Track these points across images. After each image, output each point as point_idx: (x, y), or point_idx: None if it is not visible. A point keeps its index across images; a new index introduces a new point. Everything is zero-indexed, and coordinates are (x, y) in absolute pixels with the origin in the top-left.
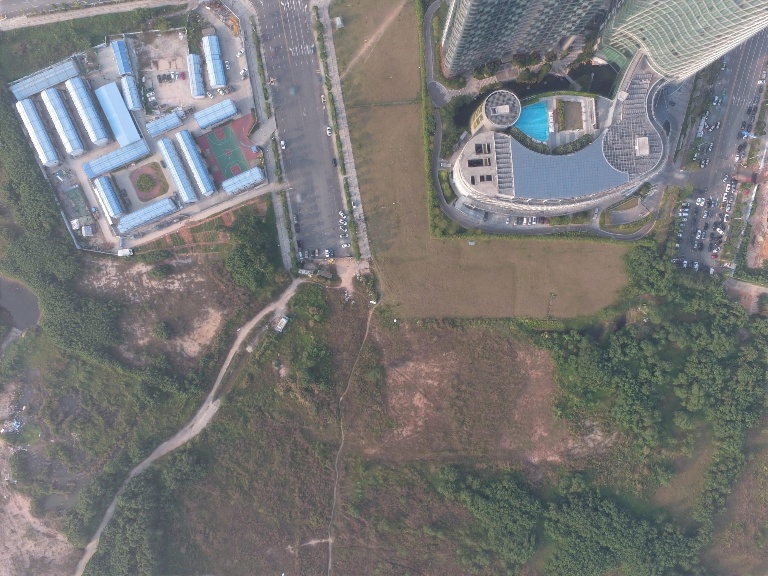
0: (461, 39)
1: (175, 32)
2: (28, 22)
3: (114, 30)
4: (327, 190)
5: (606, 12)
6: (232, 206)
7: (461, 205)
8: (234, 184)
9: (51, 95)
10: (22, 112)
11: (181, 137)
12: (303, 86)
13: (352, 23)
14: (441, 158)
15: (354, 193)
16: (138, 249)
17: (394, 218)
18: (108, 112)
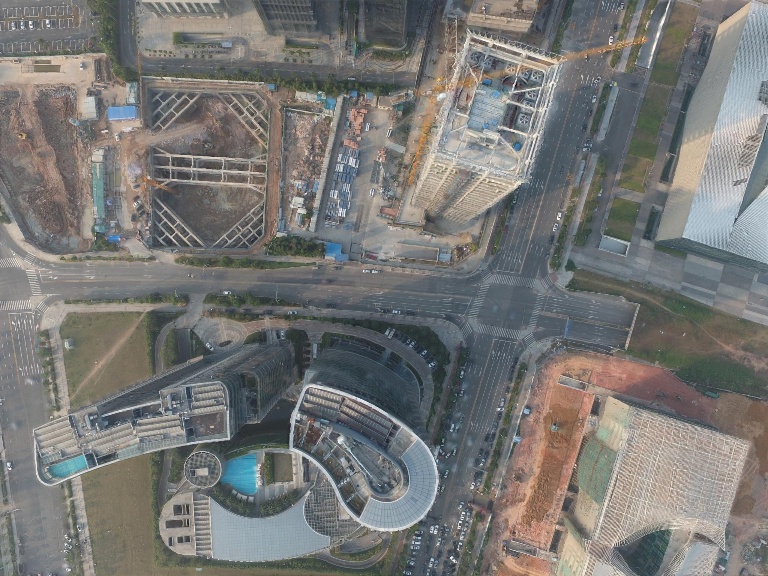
0: None
1: None
2: None
3: None
4: (53, 512)
5: None
6: None
7: None
8: None
9: None
10: None
11: None
12: (32, 406)
13: (83, 345)
14: None
15: (81, 515)
16: None
17: (120, 542)
18: None
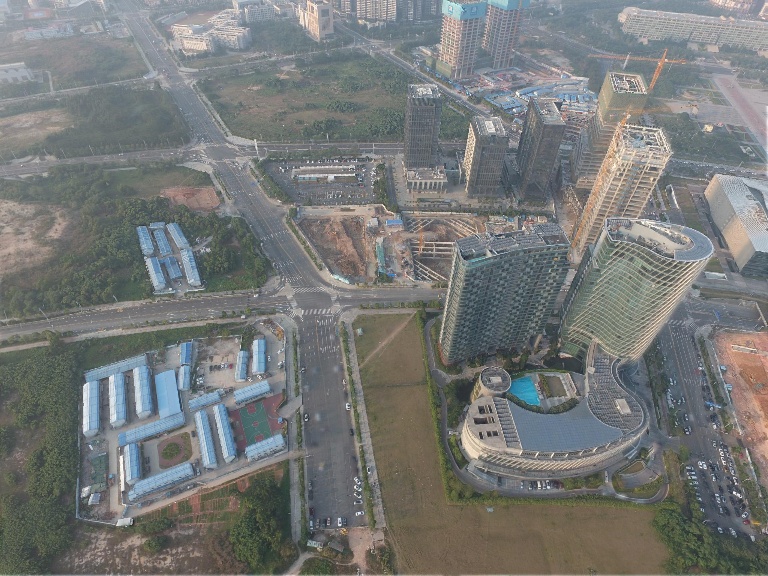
0: (455, 328)
1: (233, 338)
2: (121, 333)
3: (186, 337)
4: (343, 457)
5: (559, 323)
6: (249, 472)
7: (473, 468)
8: (256, 449)
9: (118, 378)
10: (86, 390)
11: (218, 409)
12: (328, 373)
13: (370, 332)
14: (449, 428)
15: (369, 460)
16: (140, 519)
17: (409, 484)
18: (160, 391)
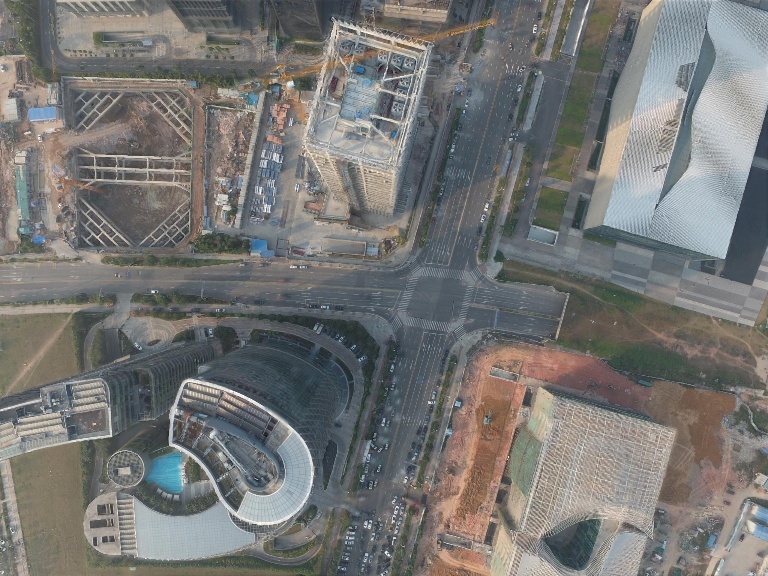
0: None
1: None
2: None
3: None
4: None
5: None
6: None
7: None
8: None
9: None
10: None
11: None
12: None
13: (11, 347)
14: None
15: (14, 517)
16: None
17: (54, 543)
18: None
